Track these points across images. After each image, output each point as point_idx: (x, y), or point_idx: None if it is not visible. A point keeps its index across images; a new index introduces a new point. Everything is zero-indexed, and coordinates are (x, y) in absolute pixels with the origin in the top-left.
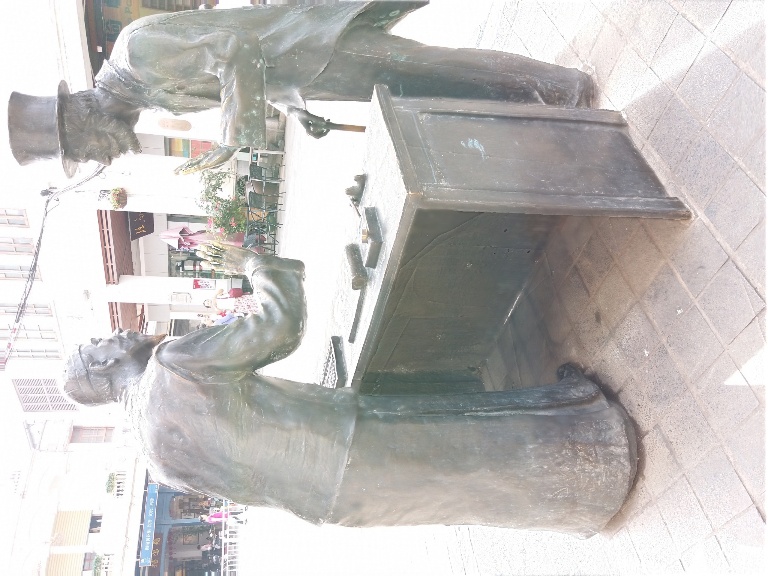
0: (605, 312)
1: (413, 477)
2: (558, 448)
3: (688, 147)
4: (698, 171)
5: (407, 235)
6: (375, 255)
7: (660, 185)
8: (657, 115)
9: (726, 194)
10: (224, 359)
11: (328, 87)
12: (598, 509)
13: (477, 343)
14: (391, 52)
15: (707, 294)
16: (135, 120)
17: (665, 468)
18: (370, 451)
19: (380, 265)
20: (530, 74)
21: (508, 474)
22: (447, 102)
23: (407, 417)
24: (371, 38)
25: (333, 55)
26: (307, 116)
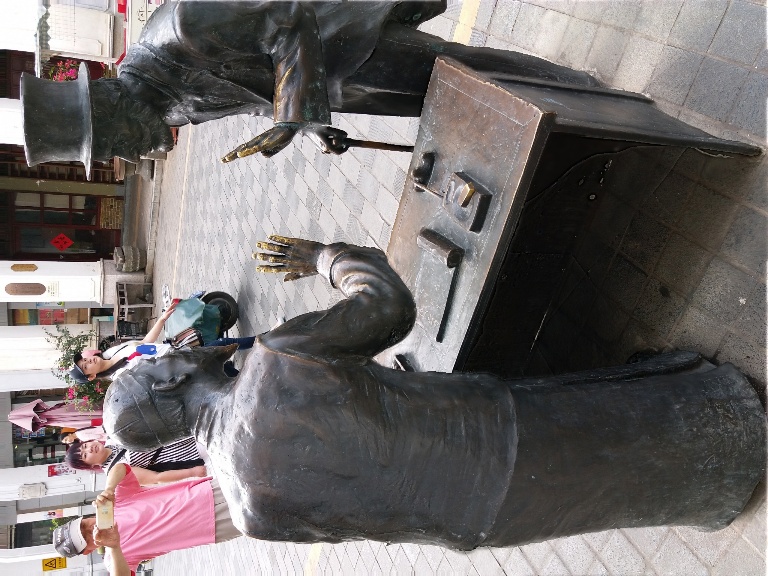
0: (673, 283)
1: (582, 453)
2: (701, 406)
3: (737, 94)
4: (757, 110)
5: (535, 169)
6: (483, 213)
7: None
8: (689, 80)
9: None
10: (347, 337)
11: (369, 79)
12: (743, 478)
13: (504, 378)
14: (429, 43)
15: None
16: (164, 115)
17: None
18: (536, 424)
19: (491, 222)
20: (549, 70)
21: (666, 441)
22: (504, 75)
23: (555, 387)
24: (407, 31)
25: (377, 42)
26: (327, 130)
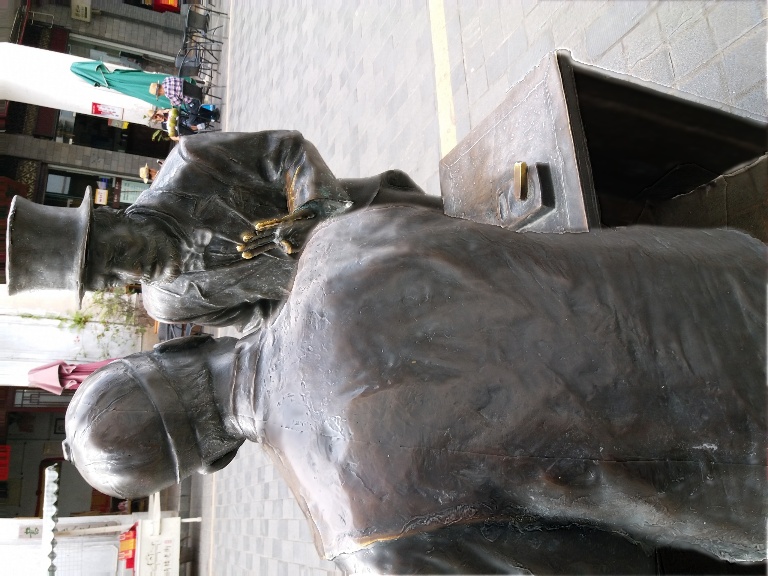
0: None
1: None
2: None
3: None
4: (762, 111)
5: (577, 102)
6: (547, 181)
7: None
8: None
9: None
10: None
11: None
12: None
13: None
14: None
15: None
16: None
17: None
18: None
19: (561, 182)
20: None
21: None
22: None
23: None
24: None
25: (381, 187)
26: None
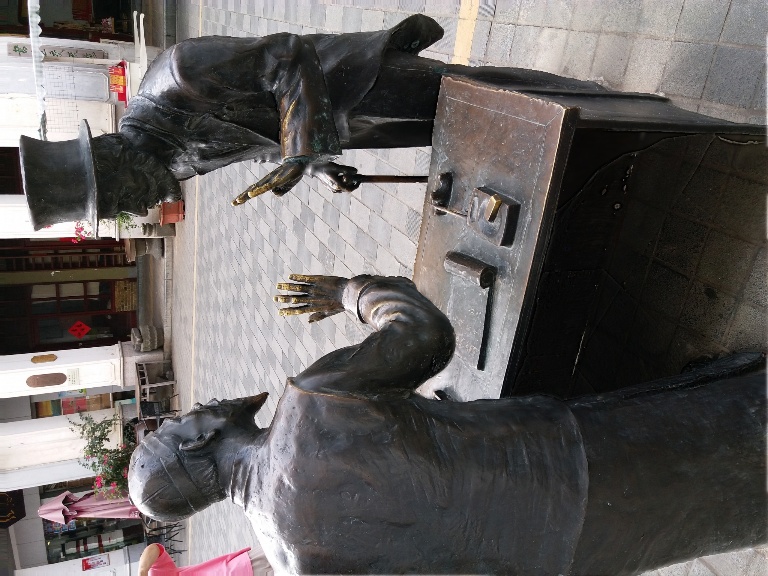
0: (719, 283)
1: (659, 472)
2: None
3: (759, 77)
4: None
5: (564, 170)
6: (513, 224)
7: None
8: (704, 72)
9: None
10: (386, 369)
11: (375, 108)
12: None
13: None
14: (432, 66)
15: None
16: (169, 165)
17: None
18: (604, 444)
19: (523, 233)
20: (556, 82)
21: (746, 450)
22: (514, 87)
23: (617, 402)
24: (408, 57)
25: (379, 70)
26: (336, 168)
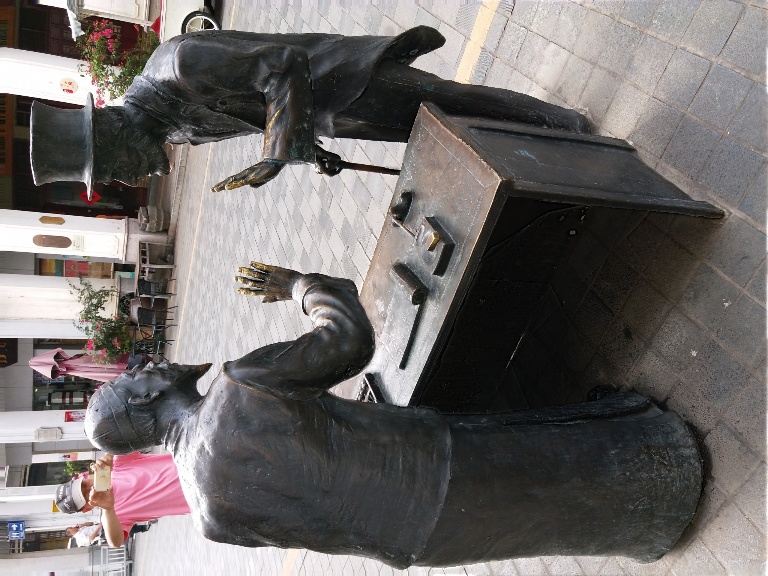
0: (636, 326)
1: (512, 491)
2: (636, 452)
3: (709, 155)
4: (725, 174)
5: (493, 228)
6: (446, 260)
7: (685, 193)
8: (669, 135)
9: (761, 187)
10: (304, 372)
11: (360, 114)
12: (673, 520)
13: (479, 392)
14: (421, 82)
15: (757, 280)
16: (163, 141)
17: (738, 461)
18: (469, 463)
19: (452, 269)
20: (539, 110)
21: (597, 483)
22: (487, 122)
23: (495, 427)
24: (401, 69)
25: (369, 81)
26: (322, 153)
